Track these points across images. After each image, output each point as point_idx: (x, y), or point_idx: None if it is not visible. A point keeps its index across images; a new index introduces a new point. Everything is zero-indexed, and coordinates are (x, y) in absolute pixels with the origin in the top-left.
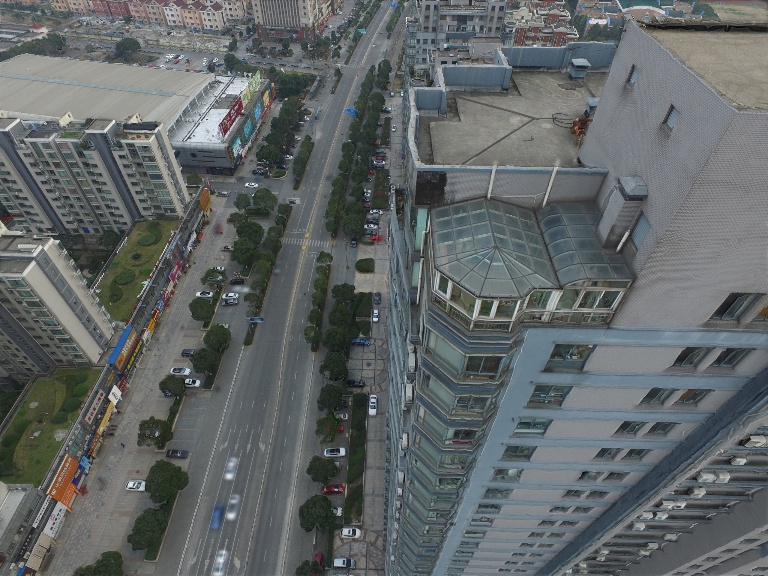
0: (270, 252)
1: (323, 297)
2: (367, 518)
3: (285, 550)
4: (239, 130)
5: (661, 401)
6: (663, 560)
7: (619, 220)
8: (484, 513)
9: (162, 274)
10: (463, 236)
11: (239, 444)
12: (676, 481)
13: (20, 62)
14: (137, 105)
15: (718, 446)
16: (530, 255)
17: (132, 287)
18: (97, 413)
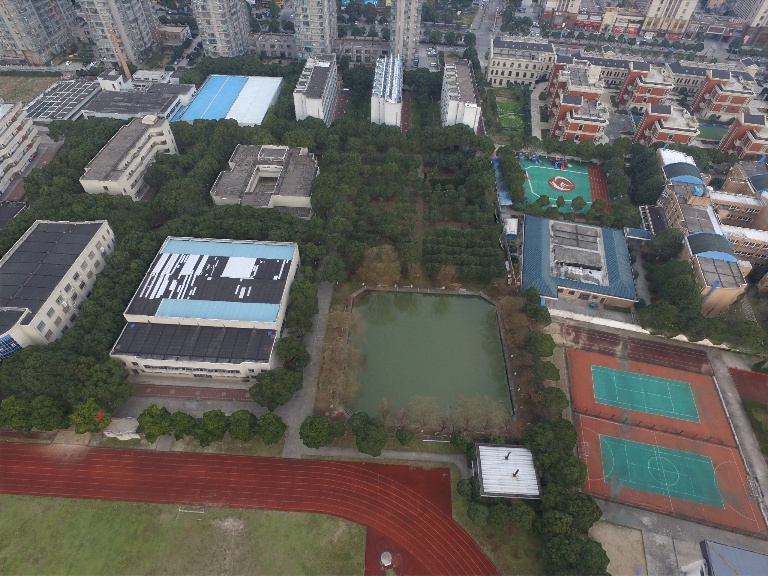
0: None
1: None
2: None
3: None
4: None
5: None
6: None
7: None
8: None
9: None
10: None
11: None
12: None
13: None
14: None
15: None
16: None
17: None
18: None
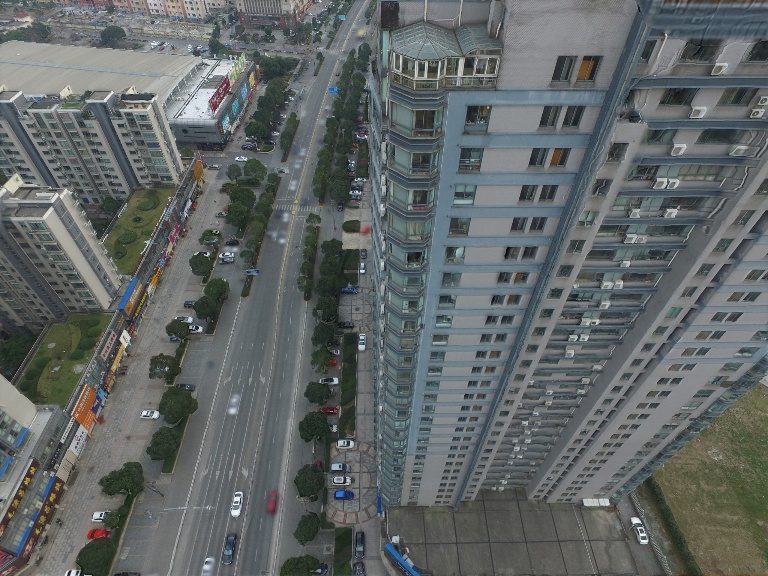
0: (262, 215)
1: (313, 252)
2: (360, 432)
3: (287, 460)
4: (227, 108)
5: (543, 165)
6: (594, 393)
7: (495, 16)
8: (444, 308)
9: (162, 235)
10: (409, 37)
11: (241, 378)
12: (576, 268)
13: (9, 48)
14: (128, 85)
15: (582, 197)
16: (447, 43)
17: (135, 246)
18: (110, 353)
